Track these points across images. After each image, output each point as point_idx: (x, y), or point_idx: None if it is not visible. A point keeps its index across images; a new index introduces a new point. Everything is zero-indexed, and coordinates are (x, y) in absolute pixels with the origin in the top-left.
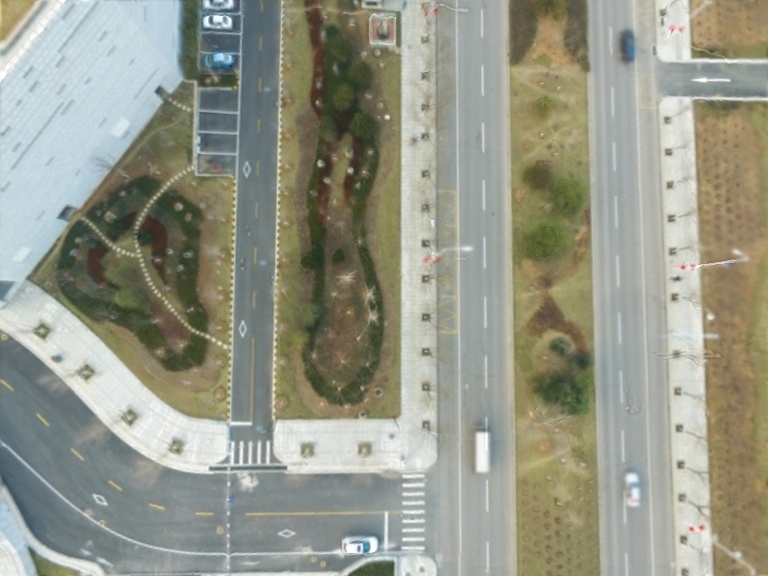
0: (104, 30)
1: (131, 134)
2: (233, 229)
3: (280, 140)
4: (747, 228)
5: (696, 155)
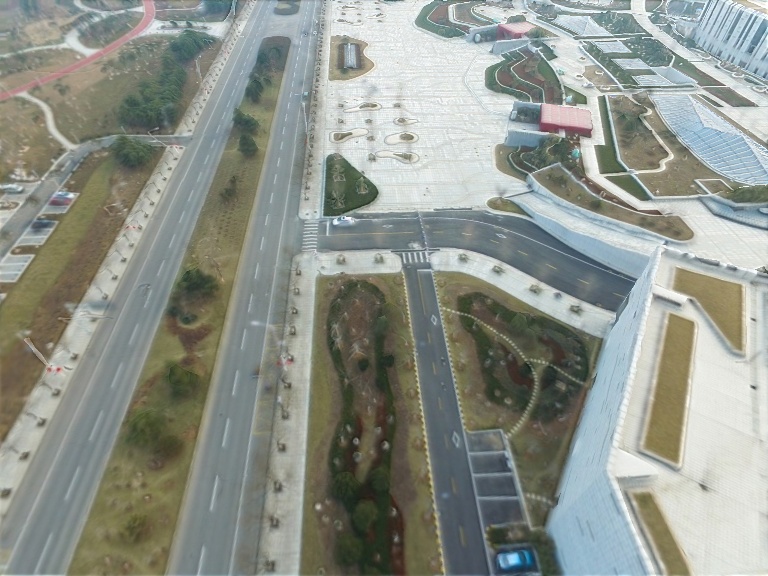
0: None
1: None
2: (457, 387)
3: (429, 471)
4: None
5: None
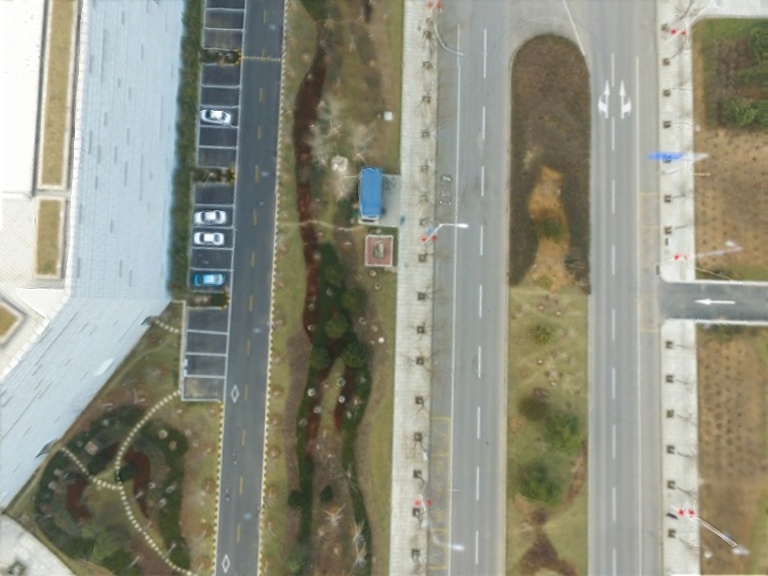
0: (85, 323)
1: (115, 363)
2: (219, 457)
3: (270, 363)
4: (748, 461)
5: (698, 382)
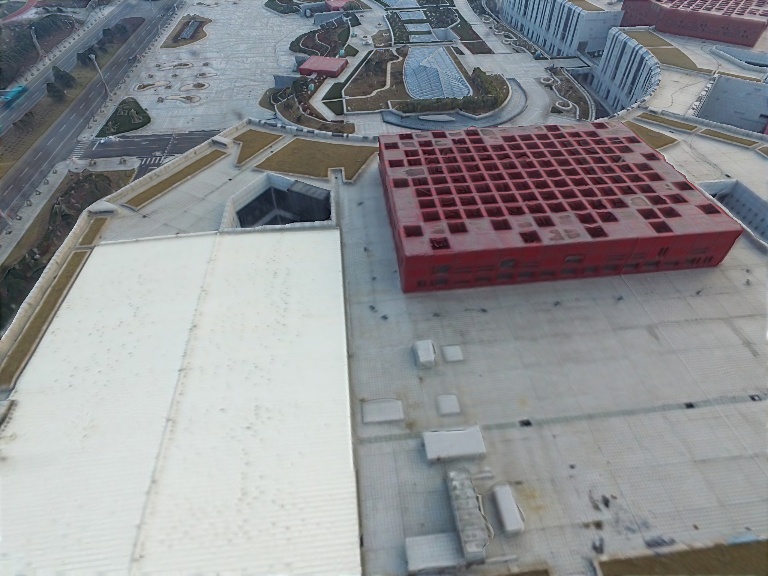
0: None
1: None
2: None
3: None
4: None
5: None
